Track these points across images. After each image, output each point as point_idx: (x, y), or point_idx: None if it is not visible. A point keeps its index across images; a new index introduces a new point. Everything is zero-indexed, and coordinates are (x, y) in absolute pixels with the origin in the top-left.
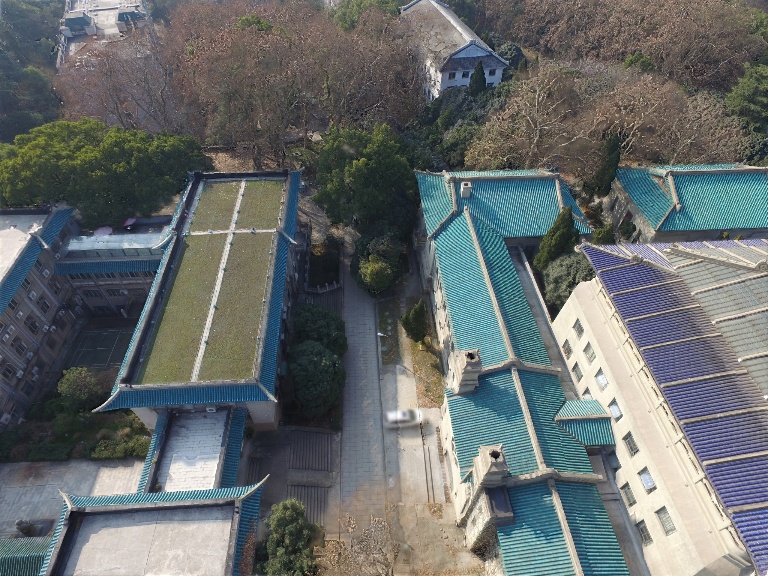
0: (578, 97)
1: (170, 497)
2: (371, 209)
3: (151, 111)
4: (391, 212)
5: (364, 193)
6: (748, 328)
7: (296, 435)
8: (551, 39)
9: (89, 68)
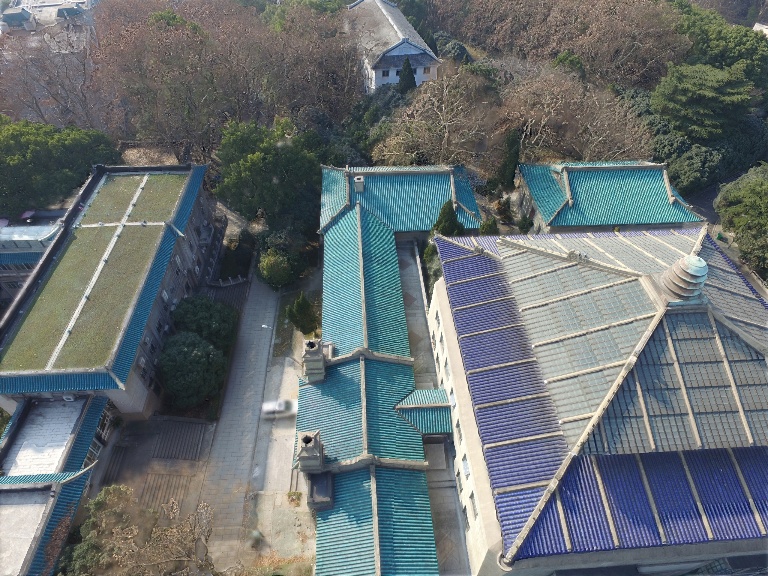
0: (496, 94)
1: None
2: (274, 203)
3: (68, 105)
4: (297, 207)
5: (263, 187)
6: (548, 316)
7: (167, 425)
8: (495, 38)
9: (3, 62)
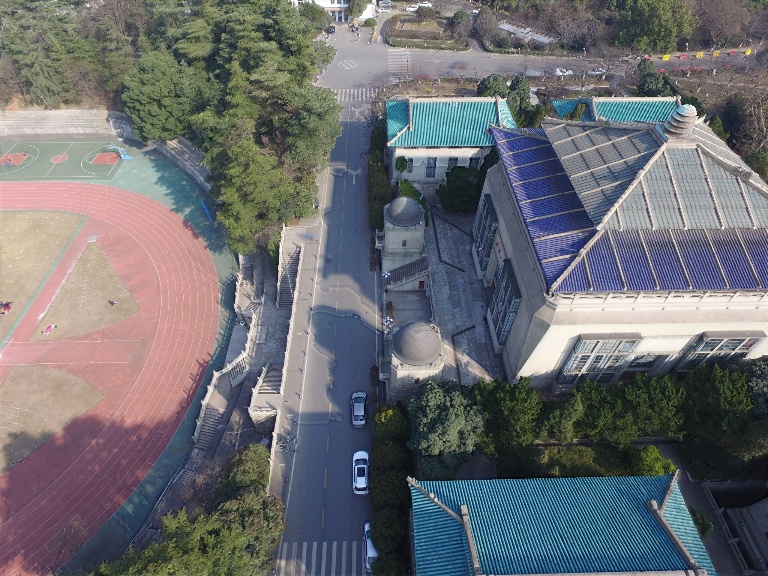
0: None
1: None
2: None
3: None
4: None
5: None
6: None
7: None
8: None
9: None
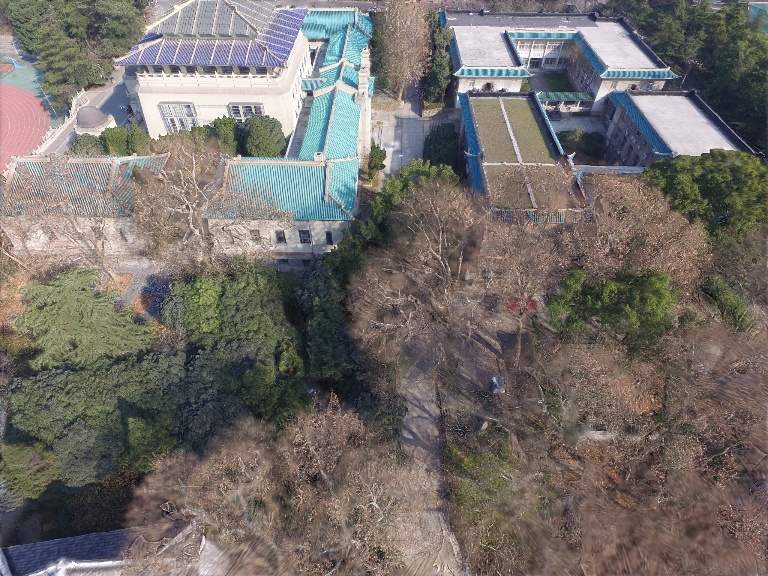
0: None
1: (490, 73)
2: None
3: None
4: None
5: None
6: None
7: None
8: None
9: None
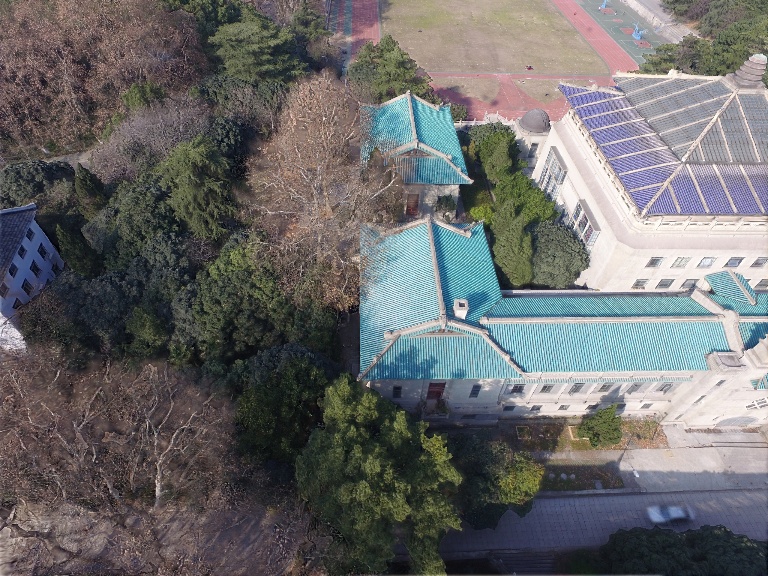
0: None
1: None
2: None
3: None
4: None
5: None
6: (765, 147)
7: None
8: None
9: None
